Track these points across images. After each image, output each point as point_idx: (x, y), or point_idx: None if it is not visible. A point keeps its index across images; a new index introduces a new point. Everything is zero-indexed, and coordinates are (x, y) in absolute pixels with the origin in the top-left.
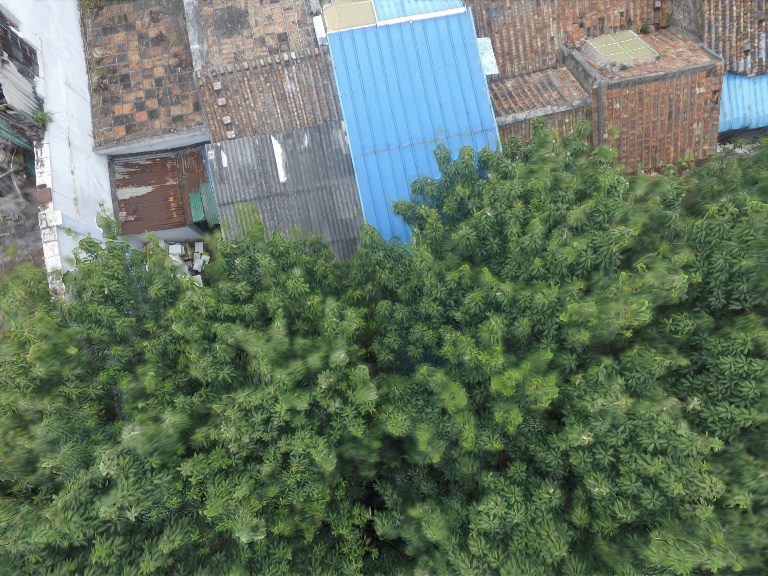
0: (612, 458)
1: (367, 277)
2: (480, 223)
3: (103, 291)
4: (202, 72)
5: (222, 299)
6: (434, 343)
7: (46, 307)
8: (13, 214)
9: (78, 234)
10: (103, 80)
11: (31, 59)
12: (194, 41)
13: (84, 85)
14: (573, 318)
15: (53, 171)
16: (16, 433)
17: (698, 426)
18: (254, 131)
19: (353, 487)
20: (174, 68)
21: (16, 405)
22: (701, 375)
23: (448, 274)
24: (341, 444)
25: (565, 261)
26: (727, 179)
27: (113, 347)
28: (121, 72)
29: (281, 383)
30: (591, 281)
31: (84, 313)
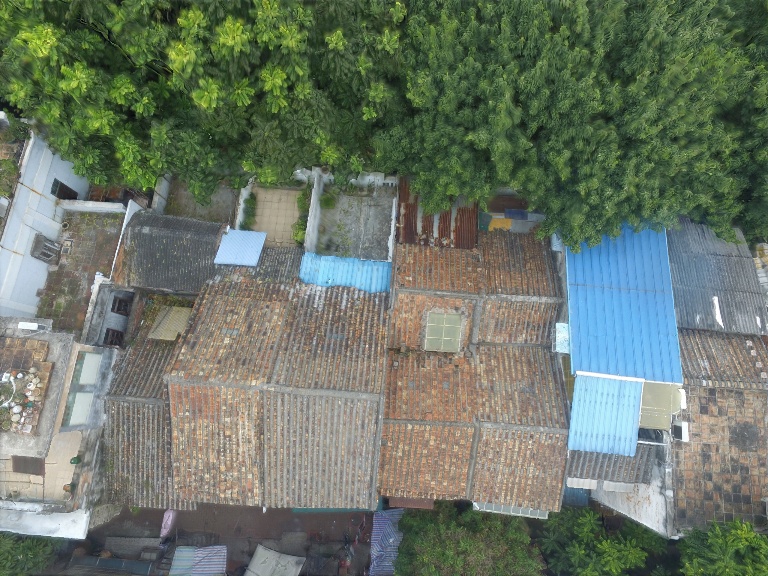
0: None
1: None
2: None
3: None
4: None
5: None
6: None
7: None
8: None
9: None
10: None
11: None
12: None
13: None
14: None
15: None
16: None
17: None
18: (730, 343)
19: None
20: None
21: None
22: None
23: None
24: None
25: None
26: None
27: None
28: None
29: None
30: None
31: None
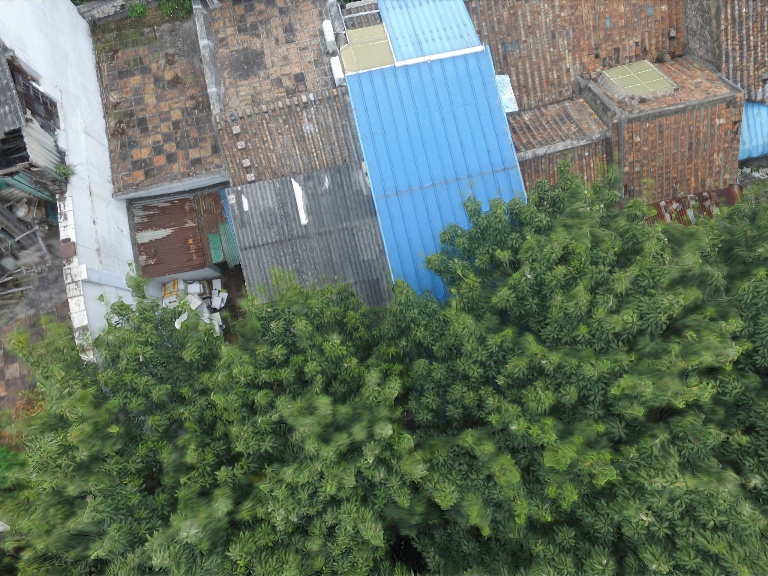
0: (667, 531)
1: (400, 331)
2: (519, 284)
3: (138, 359)
4: (221, 116)
5: (258, 364)
6: (475, 405)
7: (79, 374)
8: (36, 267)
9: (102, 285)
10: (120, 124)
11: (52, 112)
12: (211, 84)
13: (102, 130)
14: (625, 392)
15: (76, 224)
16: (56, 511)
17: (751, 493)
18: (273, 173)
19: (392, 547)
20: (191, 110)
21: (56, 482)
22: (750, 437)
23: (489, 338)
24: (385, 512)
25: (612, 330)
26: (761, 225)
27: (150, 417)
28: (138, 116)
29: (328, 461)
30: (637, 347)
31: (119, 382)
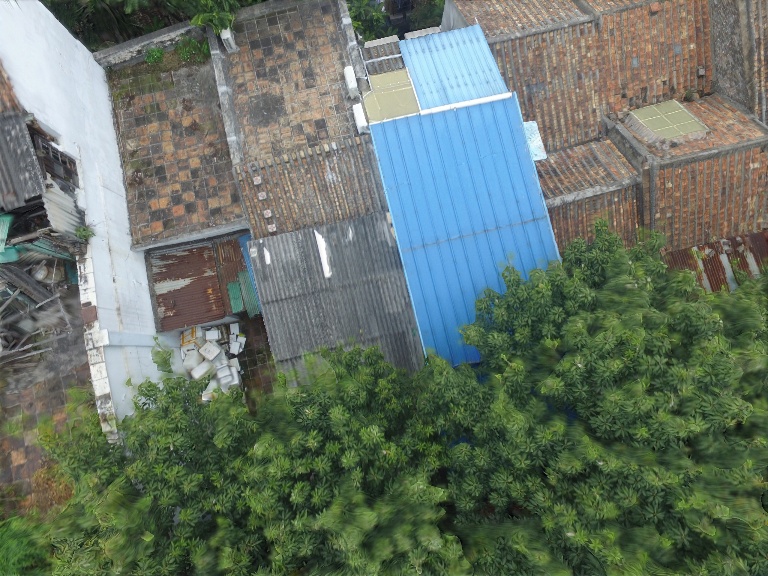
0: None
1: (437, 407)
2: (569, 372)
3: (168, 447)
4: (241, 167)
5: (294, 452)
6: (522, 497)
7: (107, 461)
8: (55, 328)
9: (123, 347)
10: (138, 173)
11: (71, 171)
12: (231, 133)
13: (119, 180)
14: (694, 506)
15: (97, 286)
16: None
17: None
18: (295, 223)
19: None
20: (210, 158)
21: None
22: None
23: (538, 431)
24: None
25: (675, 434)
26: None
27: (182, 511)
28: (156, 164)
29: (376, 574)
30: (699, 447)
31: (150, 473)
